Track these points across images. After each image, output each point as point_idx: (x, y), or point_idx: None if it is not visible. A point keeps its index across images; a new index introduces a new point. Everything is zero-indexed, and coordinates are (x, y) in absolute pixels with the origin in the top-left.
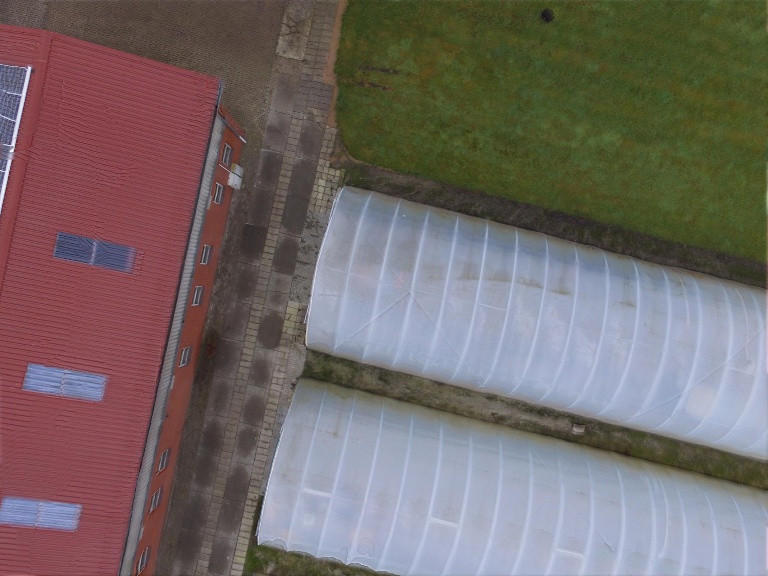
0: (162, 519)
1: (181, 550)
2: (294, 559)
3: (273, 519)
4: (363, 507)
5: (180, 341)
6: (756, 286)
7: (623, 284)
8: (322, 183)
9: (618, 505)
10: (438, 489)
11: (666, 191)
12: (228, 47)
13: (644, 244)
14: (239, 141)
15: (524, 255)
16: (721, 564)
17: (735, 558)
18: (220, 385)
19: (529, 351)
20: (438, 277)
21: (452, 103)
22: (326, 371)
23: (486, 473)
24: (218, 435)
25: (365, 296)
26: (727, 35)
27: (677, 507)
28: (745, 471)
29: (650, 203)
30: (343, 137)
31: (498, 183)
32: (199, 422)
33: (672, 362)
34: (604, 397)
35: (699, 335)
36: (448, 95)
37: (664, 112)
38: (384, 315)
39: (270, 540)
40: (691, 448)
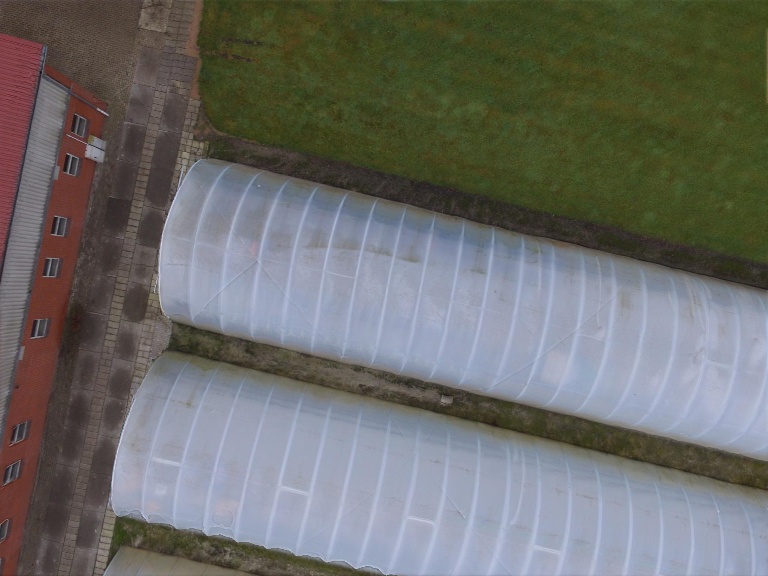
0: (29, 493)
1: (49, 524)
2: (162, 532)
3: (124, 489)
4: (213, 476)
5: (28, 312)
6: (624, 256)
7: (476, 252)
8: (186, 156)
9: (473, 473)
10: (289, 458)
11: (533, 161)
12: (90, 20)
13: (512, 215)
14: (97, 113)
15: (377, 224)
16: (574, 531)
17: (589, 525)
18: (86, 358)
19: (379, 319)
20: (286, 246)
21: (317, 74)
22: (192, 344)
23: (340, 442)
24: (84, 408)
25: (212, 265)
26: (593, 4)
27: (534, 475)
28: (614, 441)
29: (517, 173)
30: (206, 109)
31: (364, 154)
32: (65, 396)
33: (522, 329)
34: (460, 366)
35: (549, 302)
36: (312, 66)
37: (530, 82)
38: (233, 284)
39: (136, 513)
40: (560, 418)
